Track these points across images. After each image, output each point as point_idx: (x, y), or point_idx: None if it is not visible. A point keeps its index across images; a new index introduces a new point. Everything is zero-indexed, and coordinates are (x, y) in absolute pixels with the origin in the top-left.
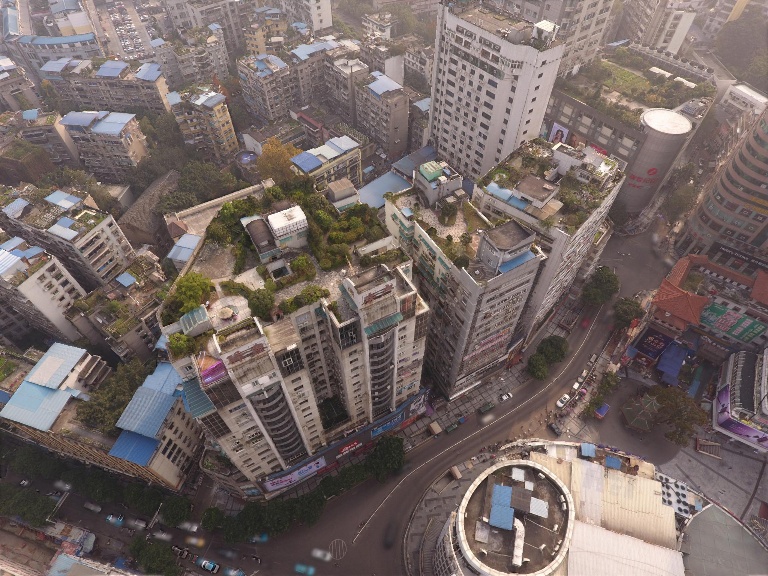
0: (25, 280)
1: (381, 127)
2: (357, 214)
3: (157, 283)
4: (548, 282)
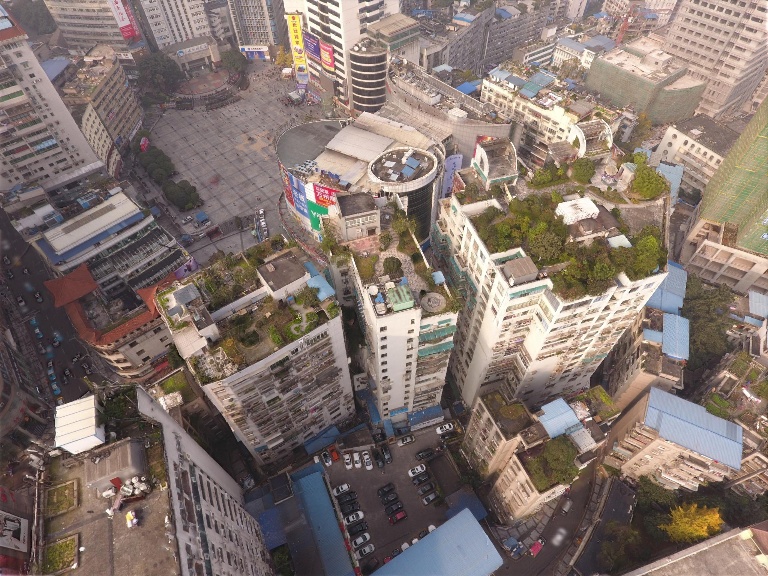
0: None
1: None
2: None
3: None
4: None
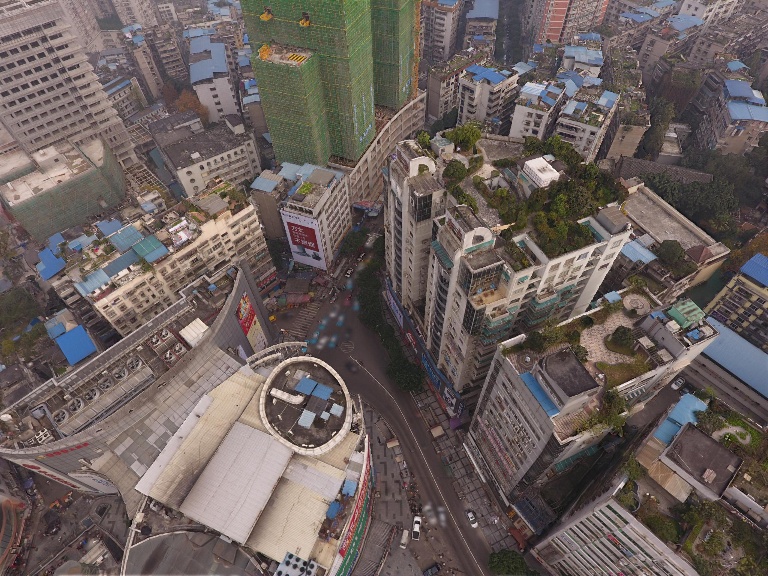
0: (523, 105)
1: None
2: (577, 233)
3: None
4: (578, 516)
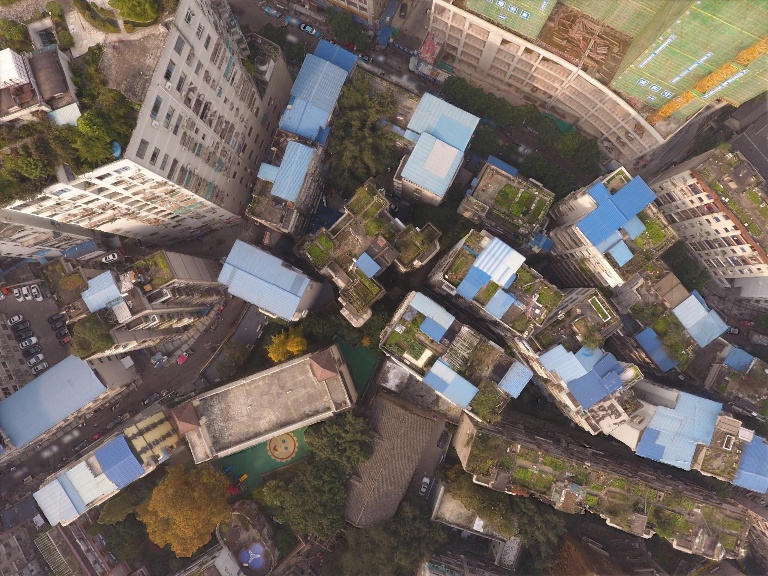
0: None
1: (4, 563)
2: None
3: (333, 261)
4: None
